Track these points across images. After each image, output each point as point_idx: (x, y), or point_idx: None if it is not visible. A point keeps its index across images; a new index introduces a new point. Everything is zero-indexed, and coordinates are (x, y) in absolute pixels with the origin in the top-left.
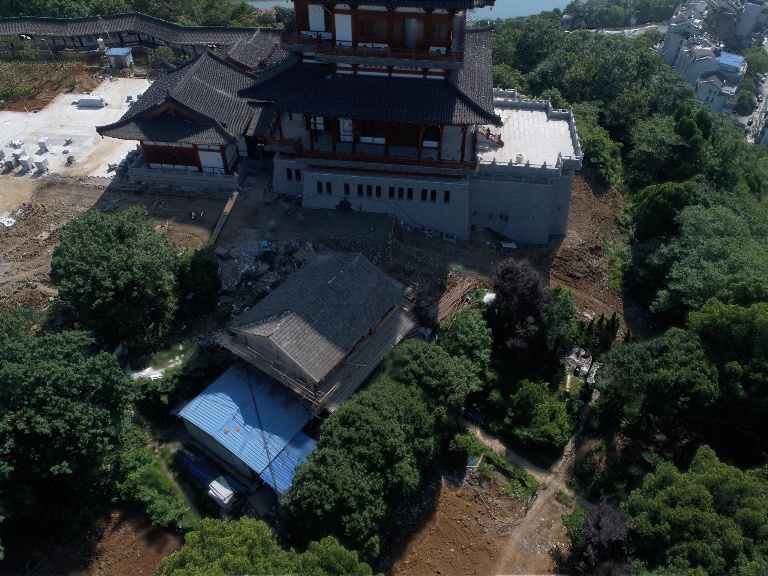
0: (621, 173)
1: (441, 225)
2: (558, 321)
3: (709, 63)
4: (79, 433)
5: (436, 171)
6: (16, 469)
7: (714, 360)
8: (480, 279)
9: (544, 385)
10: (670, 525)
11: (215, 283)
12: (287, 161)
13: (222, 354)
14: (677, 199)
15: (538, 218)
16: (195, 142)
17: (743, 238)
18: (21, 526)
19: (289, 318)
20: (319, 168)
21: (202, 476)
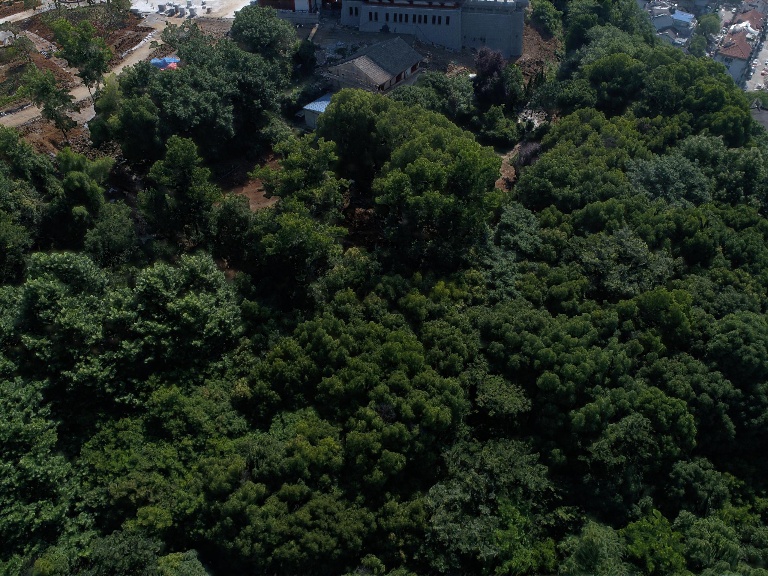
0: (561, 31)
1: (444, 41)
2: (512, 81)
3: (665, 19)
4: (265, 88)
5: (441, 1)
6: (234, 105)
7: (596, 88)
8: (467, 68)
9: (502, 105)
10: (558, 132)
11: (313, 59)
12: (350, 2)
13: (323, 86)
14: (586, 23)
15: (504, 39)
16: None
17: (621, 38)
18: (227, 149)
19: (363, 57)
20: (371, 4)
21: (316, 138)
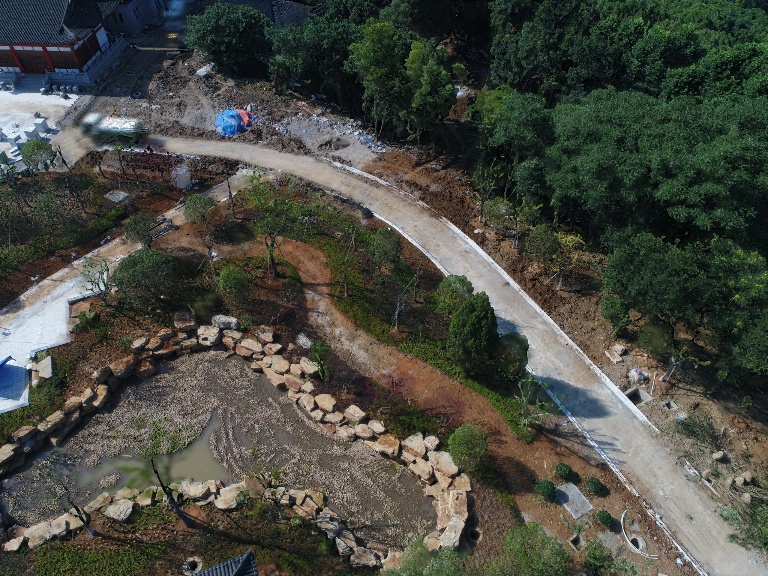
0: None
1: None
2: None
3: None
4: None
5: None
6: None
7: None
8: None
9: None
10: None
11: None
12: (131, 4)
13: None
14: None
15: None
16: (108, 13)
17: None
18: None
19: None
20: None
21: None
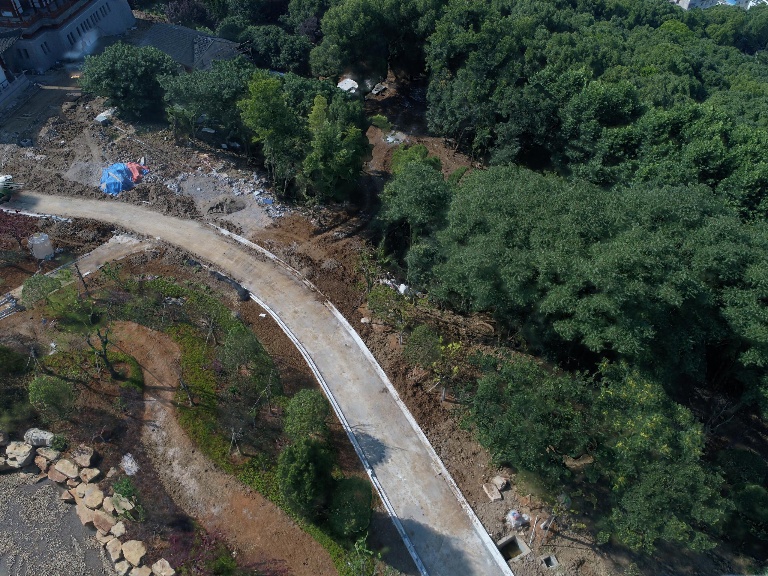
0: None
1: (116, 29)
2: None
3: None
4: None
5: None
6: None
7: None
8: None
9: None
10: None
11: None
12: (38, 38)
13: None
14: None
15: (126, 7)
16: (1, 51)
17: None
18: None
19: None
20: (59, 27)
21: None
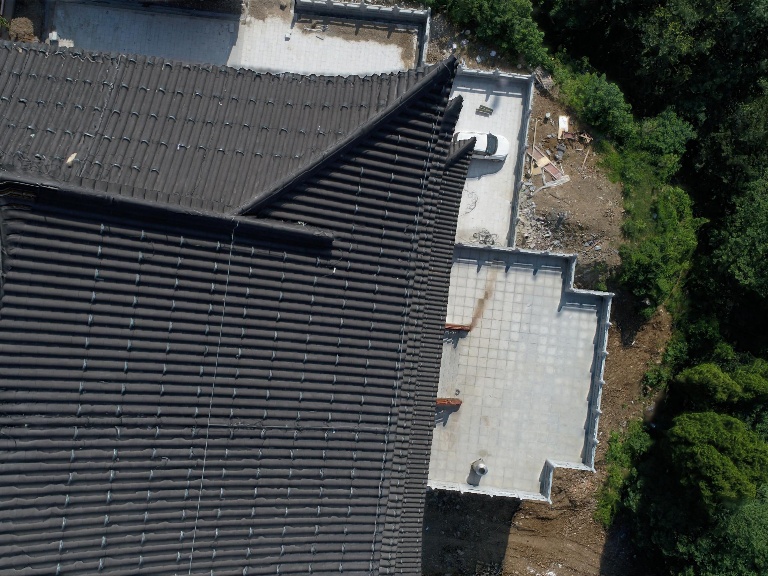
0: (686, 266)
1: None
2: None
3: None
4: None
5: None
6: None
7: None
8: None
9: None
10: None
11: None
12: None
13: None
14: None
15: None
16: None
17: None
18: None
19: None
20: None
21: None
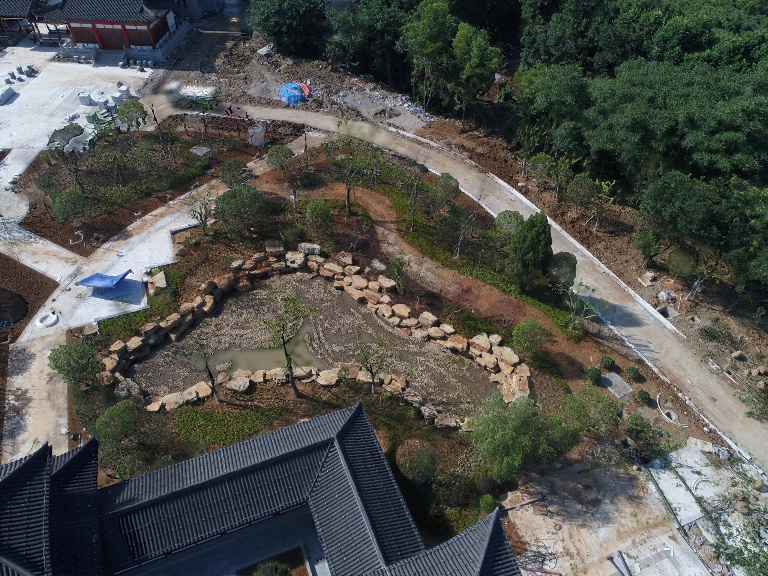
0: None
1: None
2: None
3: None
4: None
5: None
6: None
7: None
8: None
9: None
10: None
11: None
12: None
13: (330, 32)
14: None
15: None
16: None
17: None
18: None
19: None
20: None
21: None
